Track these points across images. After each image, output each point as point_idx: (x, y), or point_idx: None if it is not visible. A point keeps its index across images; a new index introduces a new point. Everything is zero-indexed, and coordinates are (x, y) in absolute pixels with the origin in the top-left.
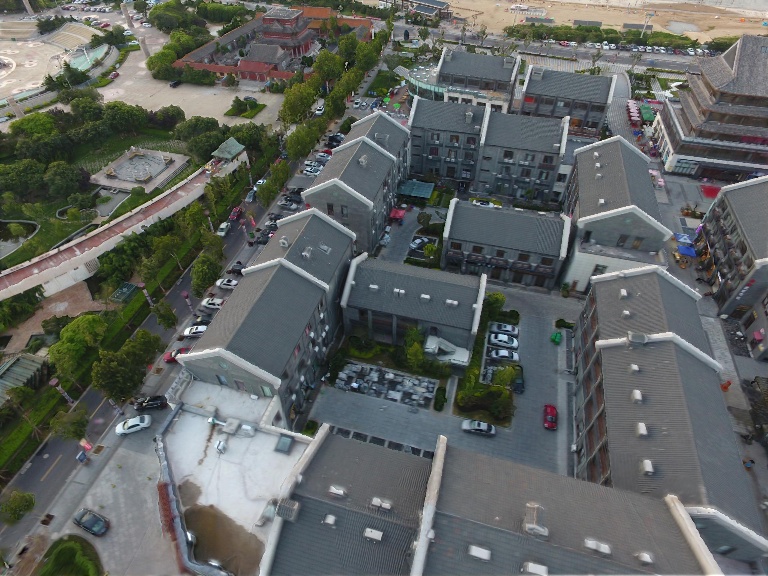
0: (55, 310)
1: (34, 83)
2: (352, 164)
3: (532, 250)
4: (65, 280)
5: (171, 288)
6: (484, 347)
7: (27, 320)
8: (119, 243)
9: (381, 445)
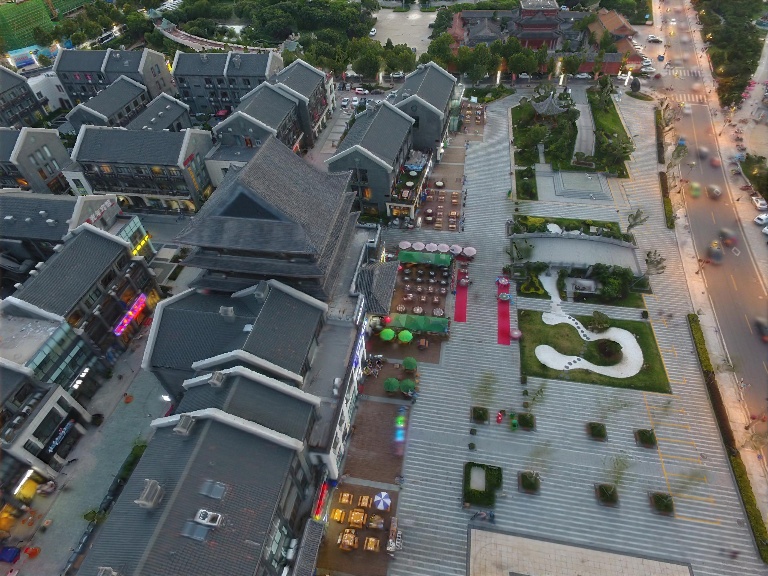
0: None
1: None
2: None
3: None
4: None
5: None
6: None
7: None
8: (209, 49)
9: None
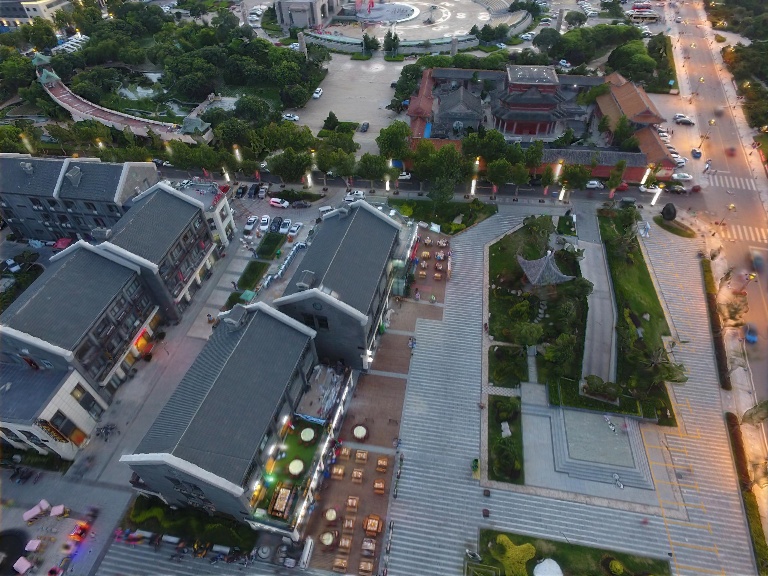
0: None
1: None
2: (26, 162)
3: None
4: (78, 119)
5: (48, 155)
6: None
7: (56, 121)
8: (89, 120)
9: None
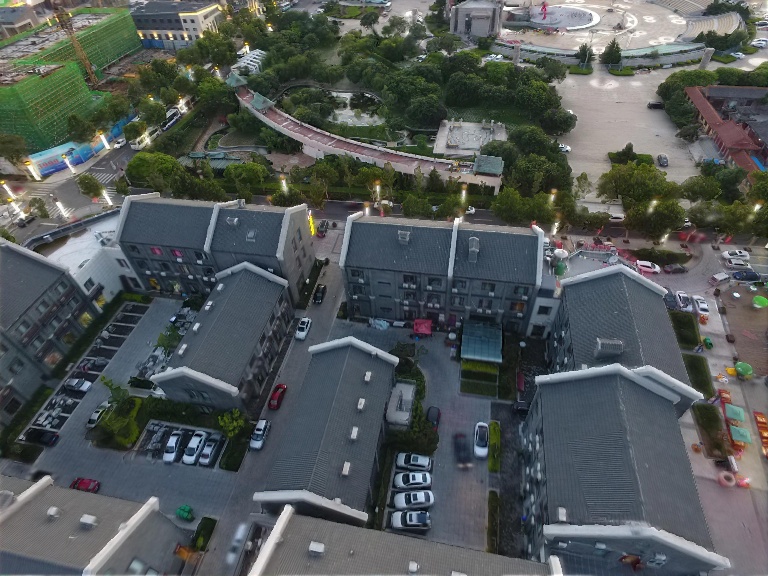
0: (291, 160)
1: (600, 49)
2: (396, 229)
3: (278, 454)
4: (313, 152)
5: None
6: (194, 426)
7: (283, 154)
8: (341, 155)
9: (116, 345)
